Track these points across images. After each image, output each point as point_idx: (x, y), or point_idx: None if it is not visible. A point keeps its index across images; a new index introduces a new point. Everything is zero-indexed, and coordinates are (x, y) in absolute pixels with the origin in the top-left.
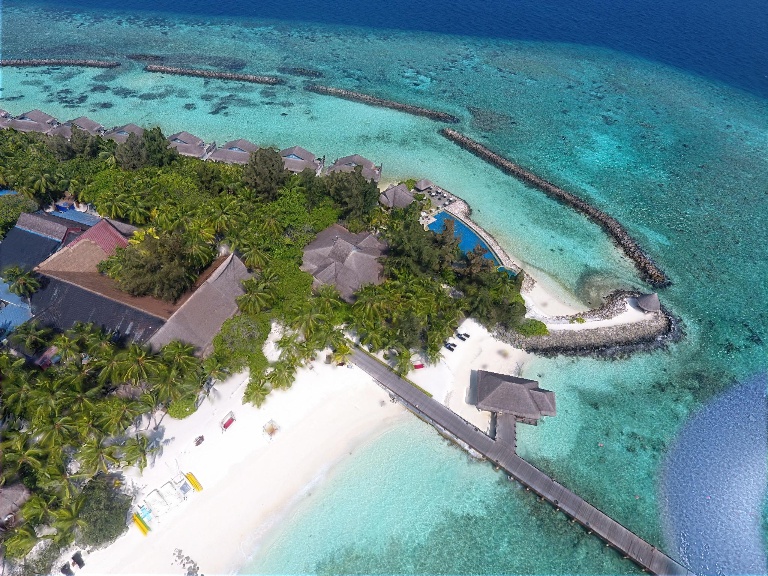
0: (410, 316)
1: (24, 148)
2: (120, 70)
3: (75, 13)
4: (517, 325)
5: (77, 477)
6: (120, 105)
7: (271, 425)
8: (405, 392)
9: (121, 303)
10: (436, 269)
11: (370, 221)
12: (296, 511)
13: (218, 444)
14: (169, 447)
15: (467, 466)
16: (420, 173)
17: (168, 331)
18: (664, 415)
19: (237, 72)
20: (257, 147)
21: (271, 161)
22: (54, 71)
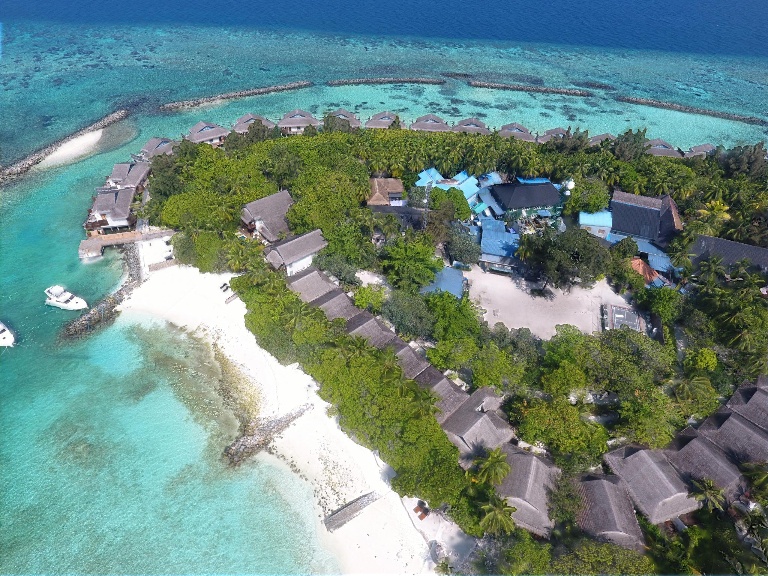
0: None
1: None
2: (452, 86)
3: (347, 38)
4: None
5: None
6: (491, 114)
7: None
8: None
9: None
10: None
11: None
12: None
13: None
14: None
15: None
16: None
17: None
18: None
19: (544, 86)
20: None
21: None
22: (402, 88)
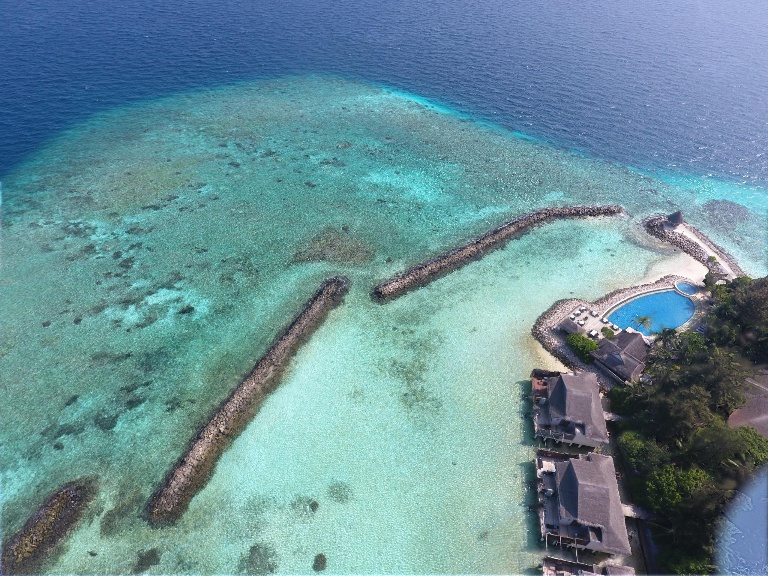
0: None
1: None
2: None
3: None
4: None
5: None
6: None
7: None
8: None
9: None
10: None
11: None
12: None
13: None
14: None
15: None
16: (509, 335)
17: None
18: (760, 247)
19: None
20: (588, 575)
21: None
22: None
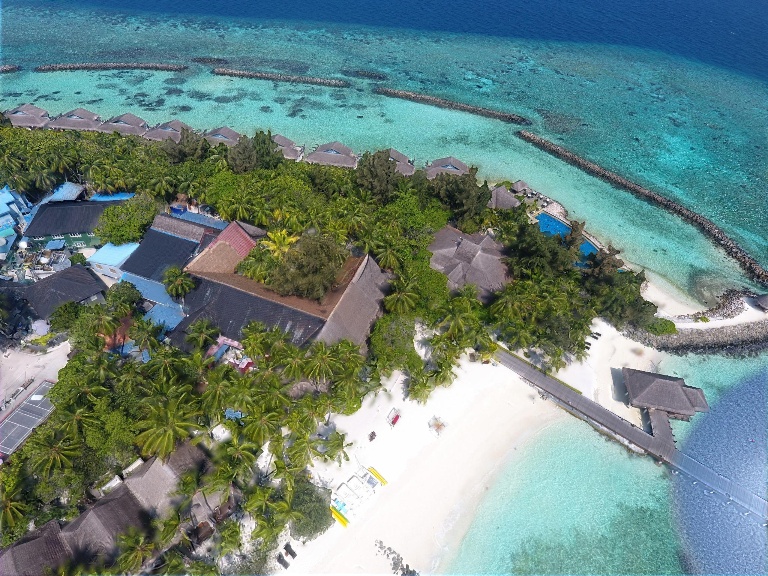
0: (551, 315)
1: (129, 151)
2: (189, 73)
3: (129, 16)
4: (647, 324)
5: (294, 470)
6: (198, 108)
7: (437, 421)
8: (554, 389)
9: (277, 303)
10: (560, 269)
11: (482, 222)
12: (478, 504)
13: (390, 439)
14: (344, 442)
15: (629, 461)
16: (507, 175)
17: (329, 330)
18: None
19: (302, 75)
20: (351, 150)
21: (387, 164)
22: (125, 74)
